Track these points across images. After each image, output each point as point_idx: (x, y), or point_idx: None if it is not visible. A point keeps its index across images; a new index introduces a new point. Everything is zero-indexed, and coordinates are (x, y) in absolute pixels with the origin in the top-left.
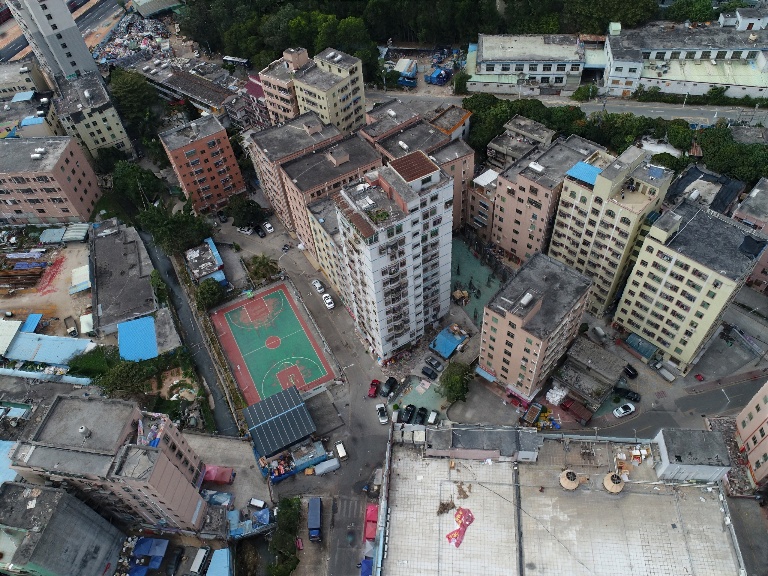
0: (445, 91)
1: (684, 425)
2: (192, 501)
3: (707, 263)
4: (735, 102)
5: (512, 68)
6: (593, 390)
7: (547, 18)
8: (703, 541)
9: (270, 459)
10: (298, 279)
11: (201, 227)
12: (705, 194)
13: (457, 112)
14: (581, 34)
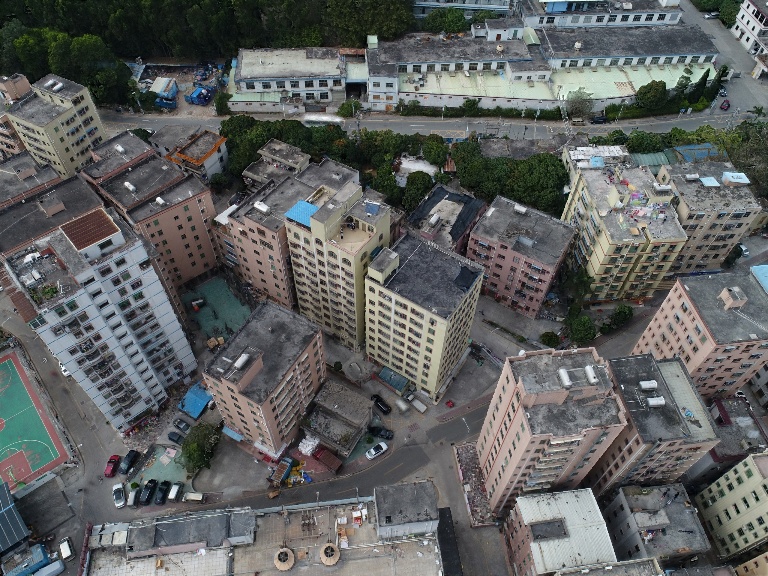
0: (208, 112)
1: (434, 457)
2: None
3: (423, 301)
4: (488, 113)
5: (273, 85)
6: (342, 436)
7: (309, 30)
8: None
9: None
10: (32, 344)
11: None
12: (449, 215)
13: (210, 138)
14: (341, 47)
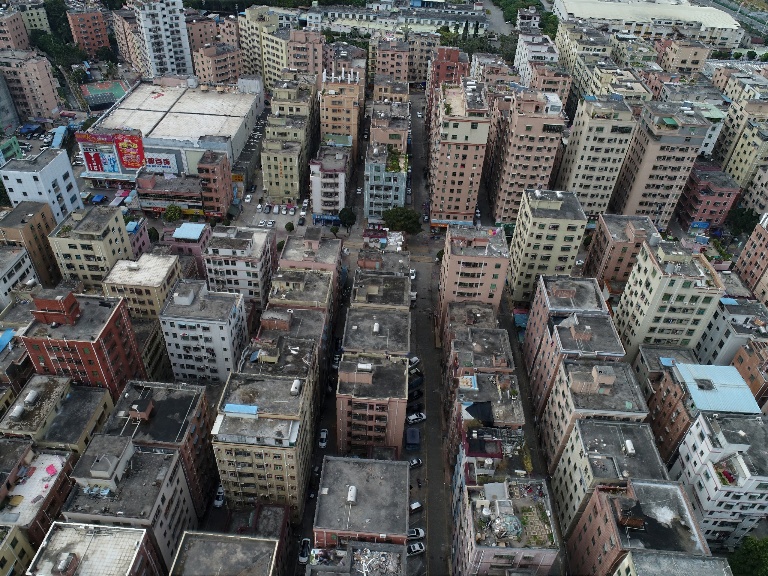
0: None
1: None
2: (53, 102)
3: None
4: None
5: None
6: None
7: (288, 0)
8: (245, 101)
9: (94, 112)
10: None
11: (81, 54)
12: None
13: None
14: (301, 6)
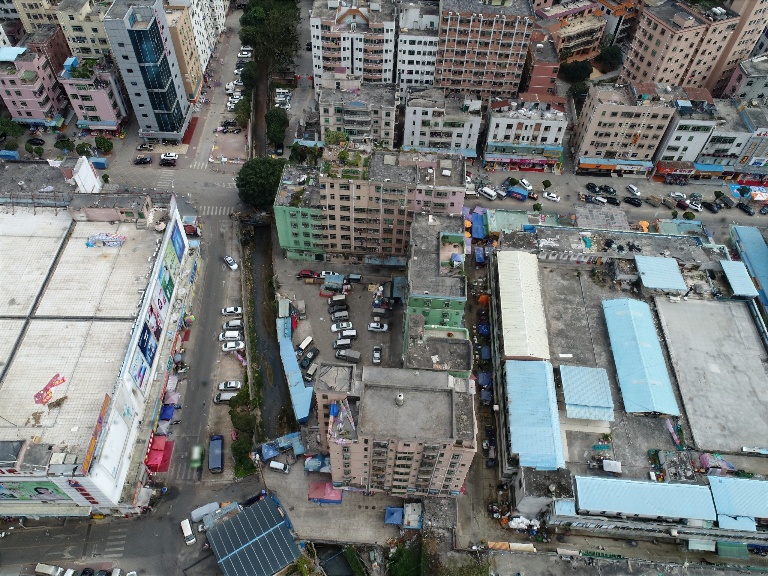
0: None
1: None
2: None
3: None
4: None
5: None
6: None
7: None
8: None
9: None
10: None
11: None
12: None
13: None
14: None
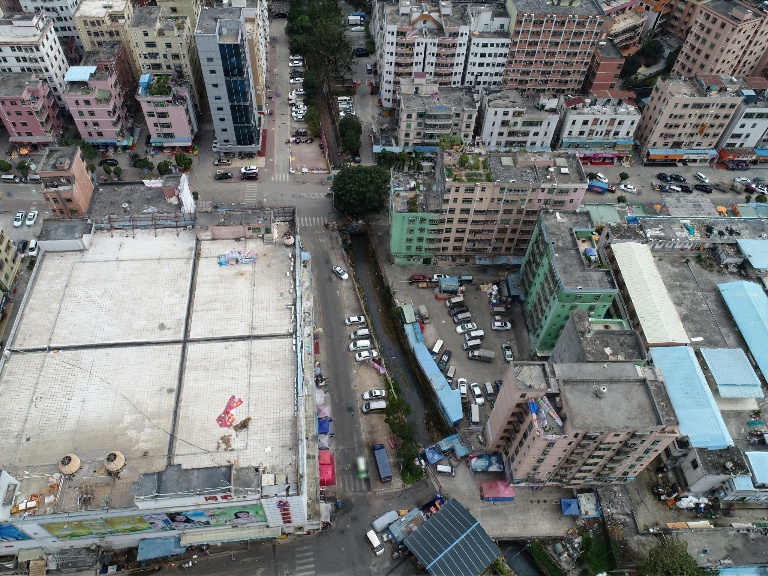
0: None
1: None
2: None
3: None
4: None
5: None
6: None
7: None
8: (7, 430)
9: None
10: None
11: None
12: None
13: None
14: None
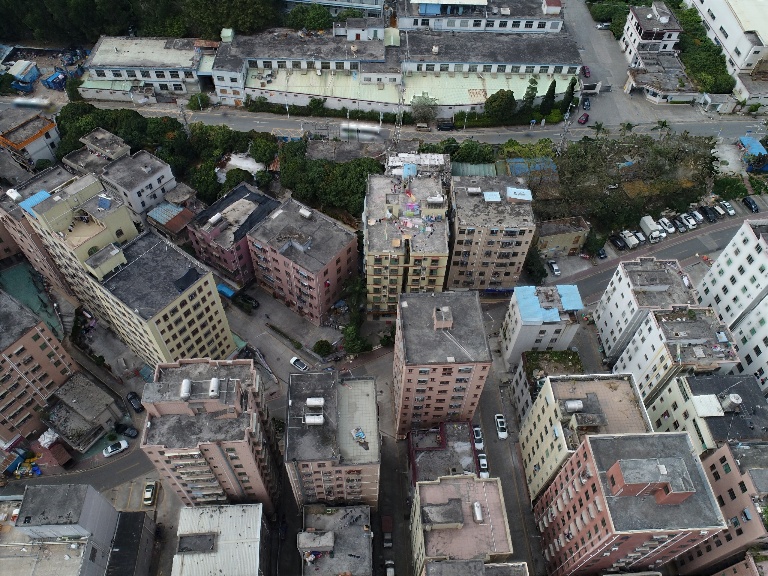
0: (62, 97)
1: None
2: None
3: (134, 300)
4: (334, 114)
5: (123, 74)
6: (77, 431)
7: (172, 20)
8: None
9: None
10: None
11: None
12: (241, 215)
13: (40, 123)
14: None
